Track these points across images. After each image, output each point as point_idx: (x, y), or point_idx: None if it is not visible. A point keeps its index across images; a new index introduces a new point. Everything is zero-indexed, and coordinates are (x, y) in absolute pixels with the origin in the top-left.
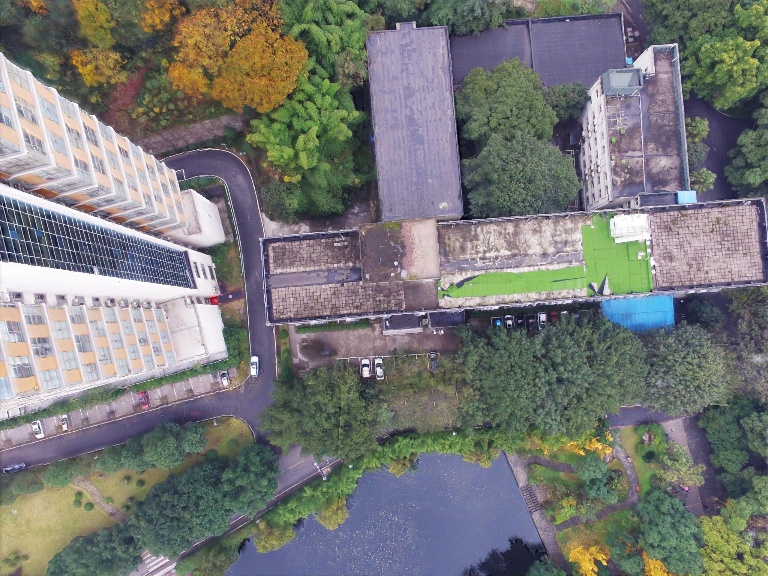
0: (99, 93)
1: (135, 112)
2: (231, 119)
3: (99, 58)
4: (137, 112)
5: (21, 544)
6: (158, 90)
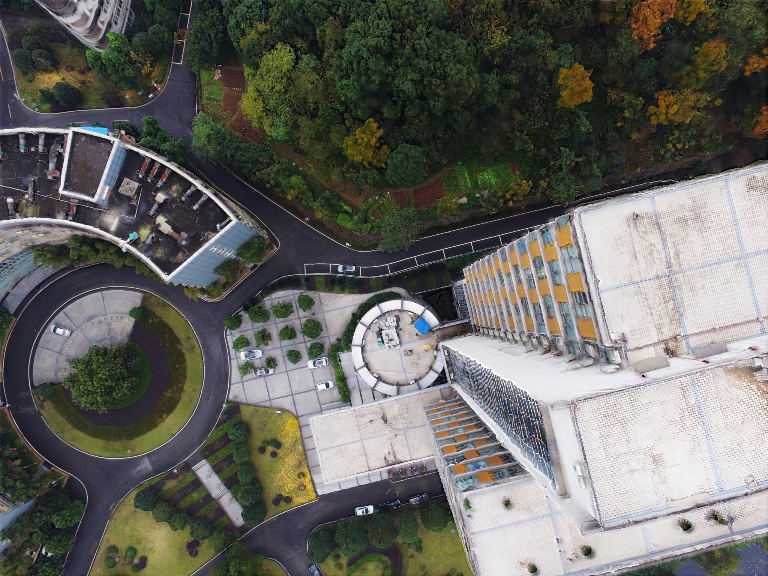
0: (638, 129)
1: (662, 148)
2: (714, 154)
3: (691, 99)
4: (664, 148)
5: (456, 562)
6: (688, 127)
